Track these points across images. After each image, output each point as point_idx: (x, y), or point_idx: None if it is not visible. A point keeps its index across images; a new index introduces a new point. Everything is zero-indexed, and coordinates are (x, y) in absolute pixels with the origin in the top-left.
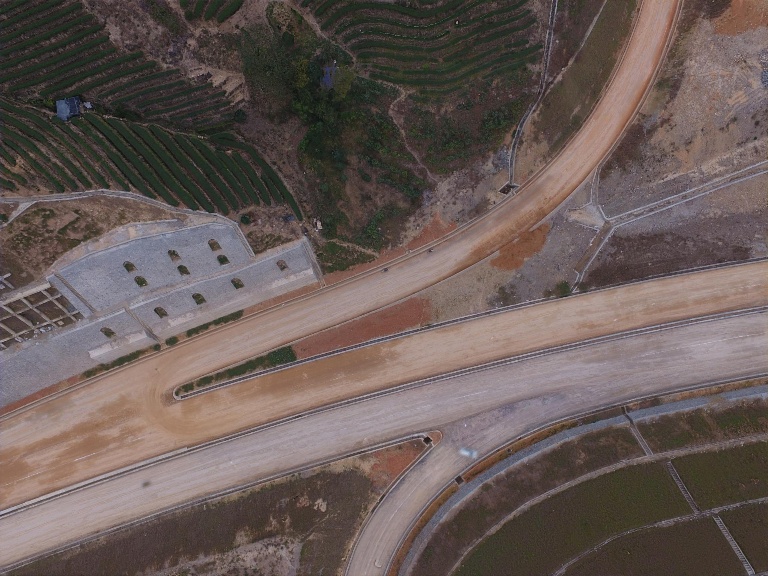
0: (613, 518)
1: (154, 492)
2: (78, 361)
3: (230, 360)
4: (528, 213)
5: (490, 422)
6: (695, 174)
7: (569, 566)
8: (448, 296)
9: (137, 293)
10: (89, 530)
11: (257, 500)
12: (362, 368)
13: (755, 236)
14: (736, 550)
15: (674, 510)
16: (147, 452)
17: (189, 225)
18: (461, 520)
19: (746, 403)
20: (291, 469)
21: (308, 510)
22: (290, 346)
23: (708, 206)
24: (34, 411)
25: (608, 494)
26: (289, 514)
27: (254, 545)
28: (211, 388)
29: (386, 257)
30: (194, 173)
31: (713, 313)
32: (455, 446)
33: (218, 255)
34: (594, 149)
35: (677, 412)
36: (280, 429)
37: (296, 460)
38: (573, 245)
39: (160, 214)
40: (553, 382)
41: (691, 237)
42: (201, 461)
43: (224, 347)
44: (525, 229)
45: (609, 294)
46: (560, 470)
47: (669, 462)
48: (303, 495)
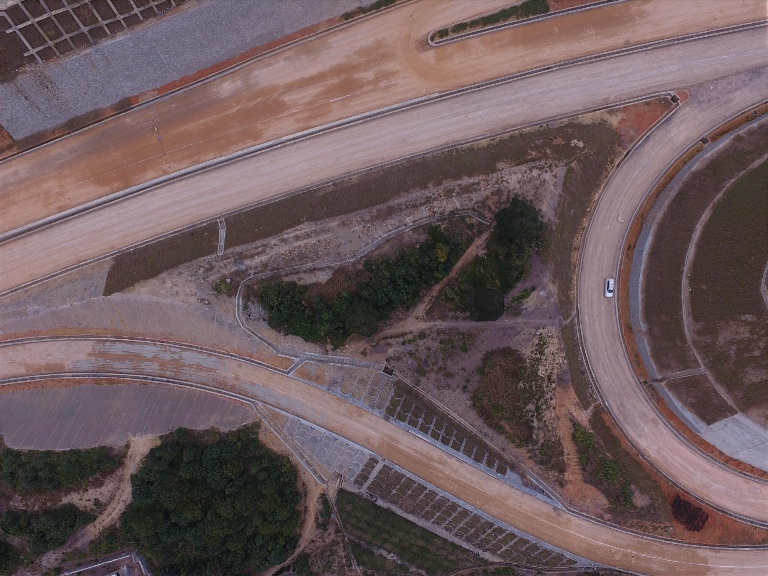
0: None
1: (404, 137)
2: None
3: (484, 9)
4: None
5: (736, 85)
6: None
7: None
8: None
9: None
10: (340, 171)
11: (508, 144)
12: (612, 25)
13: None
14: None
15: None
16: (399, 97)
17: None
18: (715, 165)
19: None
20: (539, 121)
21: (566, 145)
22: None
23: None
24: (292, 52)
25: None
26: (548, 147)
27: (519, 167)
28: (465, 36)
29: None
30: None
31: None
32: (700, 107)
33: None
34: None
35: None
36: (529, 82)
37: (543, 113)
38: None
39: None
40: None
41: None
42: (451, 109)
43: None
44: None
45: None
46: None
47: None
48: (556, 137)
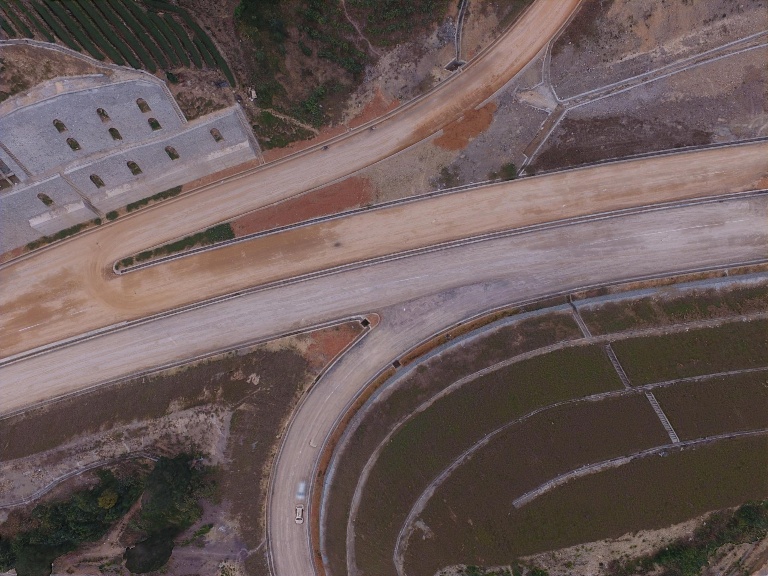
0: (541, 392)
1: (95, 365)
2: (20, 231)
3: (169, 236)
4: (475, 91)
5: (430, 307)
6: (656, 54)
7: (492, 436)
8: (389, 176)
9: (71, 158)
10: (34, 399)
11: (193, 374)
12: (300, 248)
13: (718, 120)
14: (663, 421)
15: (605, 385)
16: (88, 325)
17: (115, 81)
18: (394, 399)
19: (698, 293)
20: (228, 347)
21: (241, 383)
22: (228, 223)
23: (670, 89)
24: None
25: (540, 372)
26: (222, 386)
27: (185, 412)
28: (150, 263)
29: (326, 135)
30: (123, 30)
31: (669, 201)
32: (393, 330)
33: (149, 118)
34: (547, 24)
35: (623, 300)
36: (218, 307)
37: (234, 338)
38: (521, 126)
39: (85, 68)
40: (496, 268)
41: (648, 120)
42: (141, 336)
43: (163, 223)
44: (471, 108)
45: (558, 179)
46: (495, 351)
47: (608, 345)
48: (238, 370)
